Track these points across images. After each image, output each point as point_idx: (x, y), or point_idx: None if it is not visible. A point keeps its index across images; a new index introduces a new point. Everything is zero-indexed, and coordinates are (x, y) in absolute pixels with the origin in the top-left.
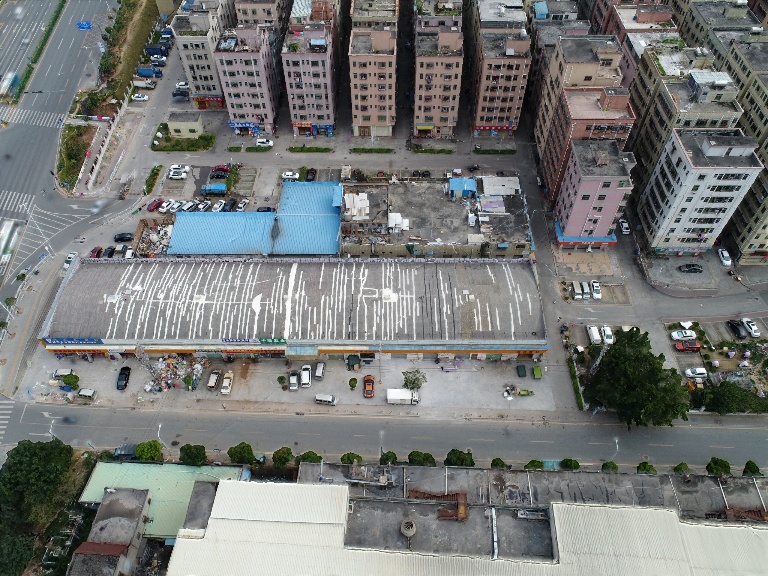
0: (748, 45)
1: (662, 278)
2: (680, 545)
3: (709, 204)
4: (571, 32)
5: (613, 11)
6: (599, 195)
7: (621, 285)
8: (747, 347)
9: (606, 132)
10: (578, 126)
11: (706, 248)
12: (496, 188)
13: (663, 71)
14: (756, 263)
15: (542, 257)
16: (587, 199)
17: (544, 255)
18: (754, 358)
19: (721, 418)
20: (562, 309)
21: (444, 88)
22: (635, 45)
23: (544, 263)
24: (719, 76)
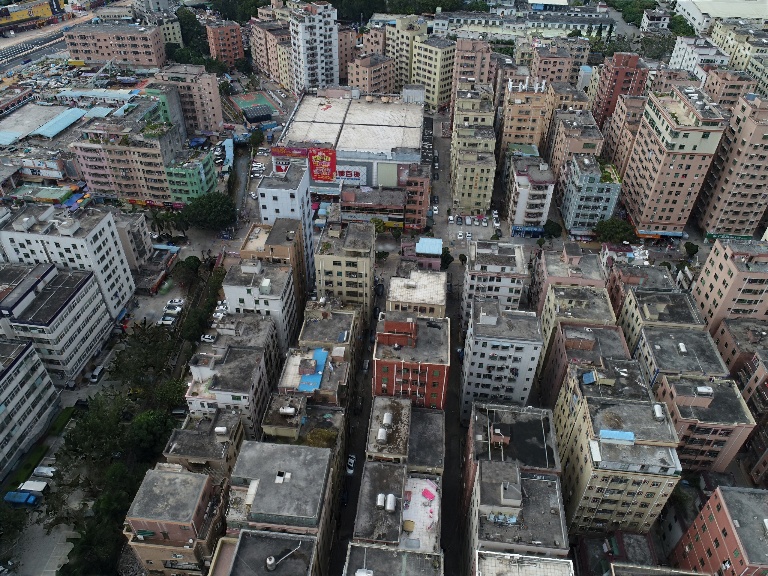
0: None
1: None
2: (762, 16)
3: None
4: None
5: None
6: None
7: None
8: None
9: None
10: None
11: None
12: None
13: None
14: None
15: None
16: None
17: None
18: None
19: None
20: None
21: None
22: None
23: None
24: None
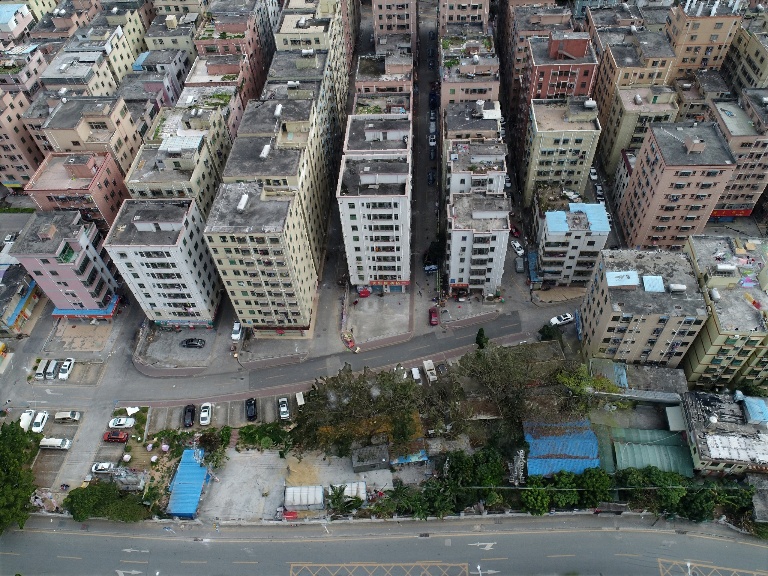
0: (261, 103)
1: (158, 354)
2: None
3: (161, 280)
4: (147, 86)
5: (197, 62)
6: (49, 271)
7: (101, 363)
8: (176, 438)
9: (70, 202)
10: (38, 197)
11: (206, 322)
12: (10, 256)
13: (156, 134)
14: (272, 336)
15: (40, 330)
16: (42, 274)
17: (44, 328)
18: (175, 451)
19: (91, 523)
20: (18, 391)
21: (4, 148)
22: (180, 101)
23: (37, 337)
24: (189, 141)
